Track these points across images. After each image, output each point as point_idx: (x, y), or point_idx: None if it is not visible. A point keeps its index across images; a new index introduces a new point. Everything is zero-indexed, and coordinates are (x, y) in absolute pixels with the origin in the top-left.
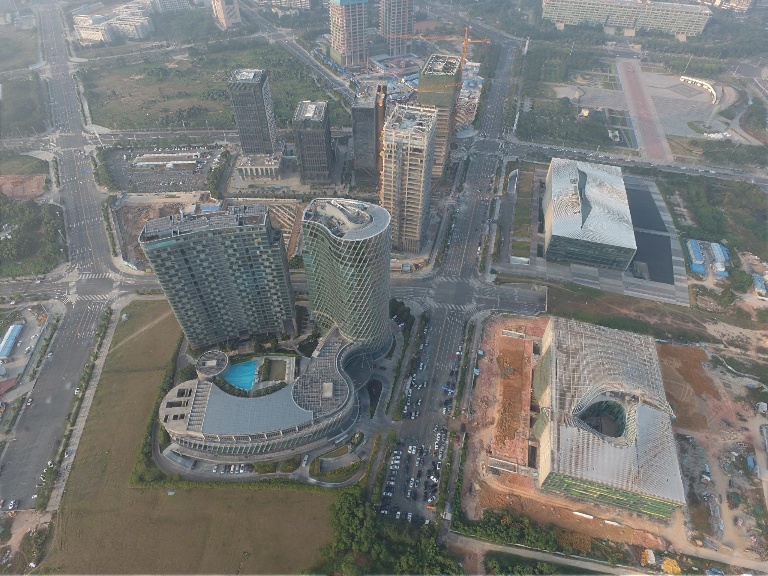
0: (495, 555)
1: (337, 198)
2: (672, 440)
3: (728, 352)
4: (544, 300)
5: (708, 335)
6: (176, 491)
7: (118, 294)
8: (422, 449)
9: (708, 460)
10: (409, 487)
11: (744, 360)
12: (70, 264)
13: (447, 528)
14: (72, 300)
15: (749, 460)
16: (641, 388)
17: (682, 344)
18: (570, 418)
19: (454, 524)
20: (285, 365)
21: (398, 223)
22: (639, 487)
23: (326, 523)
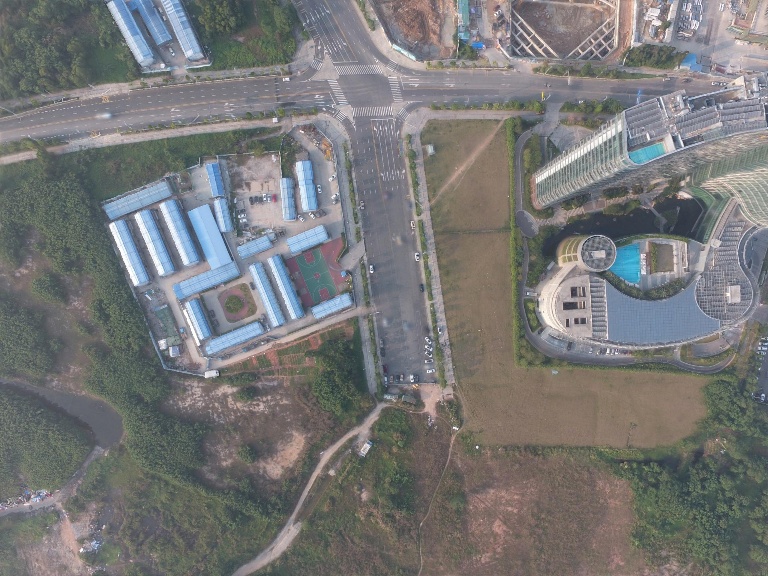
0: None
1: None
2: None
3: None
4: None
5: None
6: (559, 370)
7: (404, 106)
8: None
9: None
10: None
11: None
12: (313, 44)
13: None
14: (348, 115)
15: None
16: None
17: None
18: None
19: None
20: (672, 251)
21: None
22: None
23: (700, 402)
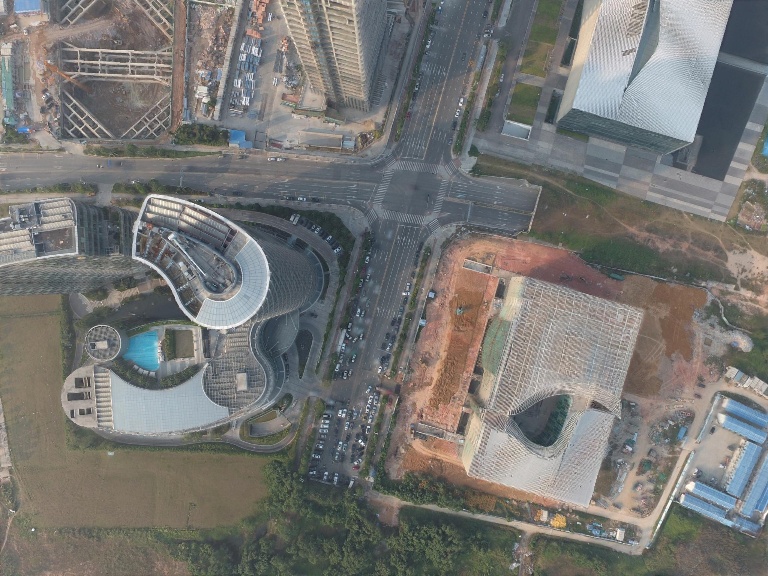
0: (409, 509)
1: (184, 201)
2: (604, 446)
3: (735, 297)
4: (533, 205)
5: (724, 271)
6: (115, 452)
7: None
8: (352, 412)
9: (640, 428)
10: (337, 450)
11: (748, 309)
12: None
13: (370, 486)
14: None
15: (681, 432)
16: (596, 389)
17: (684, 284)
18: (505, 420)
19: (376, 487)
20: (191, 337)
21: (330, 82)
22: (550, 493)
23: (260, 482)
